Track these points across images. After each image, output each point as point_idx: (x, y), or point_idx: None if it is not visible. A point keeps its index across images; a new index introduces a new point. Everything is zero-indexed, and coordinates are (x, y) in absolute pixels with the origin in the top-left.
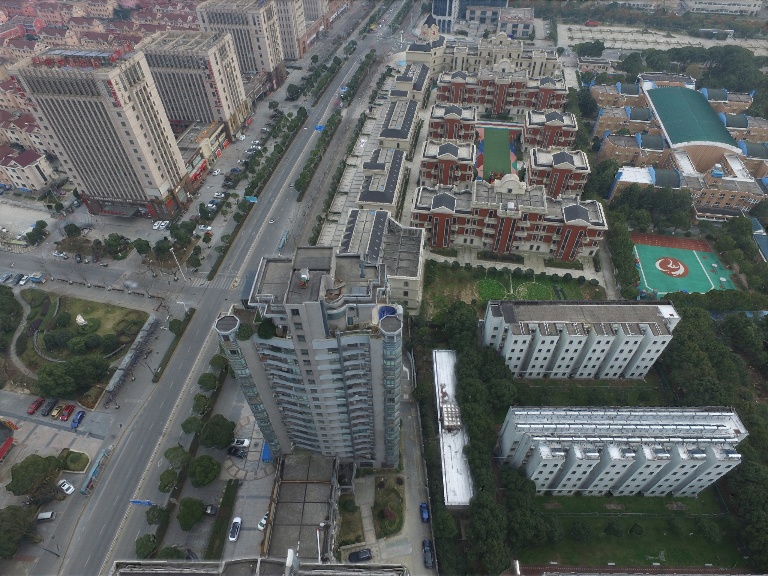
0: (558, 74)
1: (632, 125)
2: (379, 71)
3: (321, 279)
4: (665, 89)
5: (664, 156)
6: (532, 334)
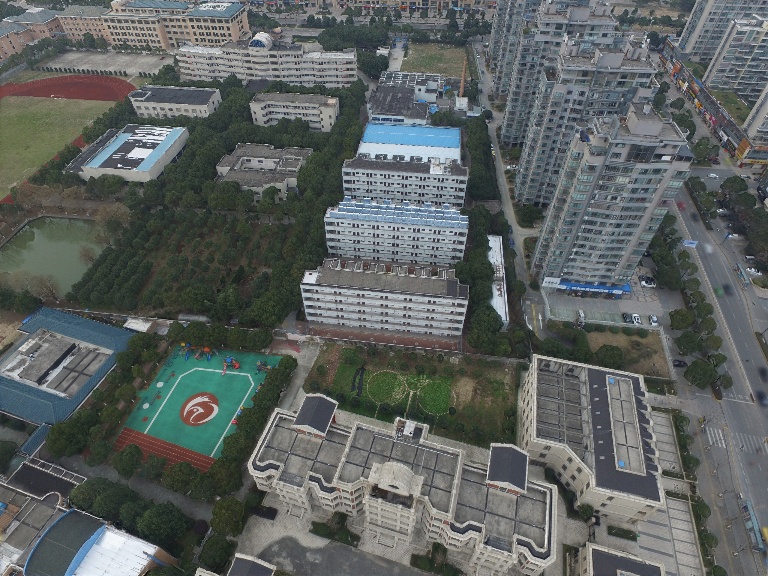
0: None
1: None
2: None
3: None
4: None
5: None
6: None
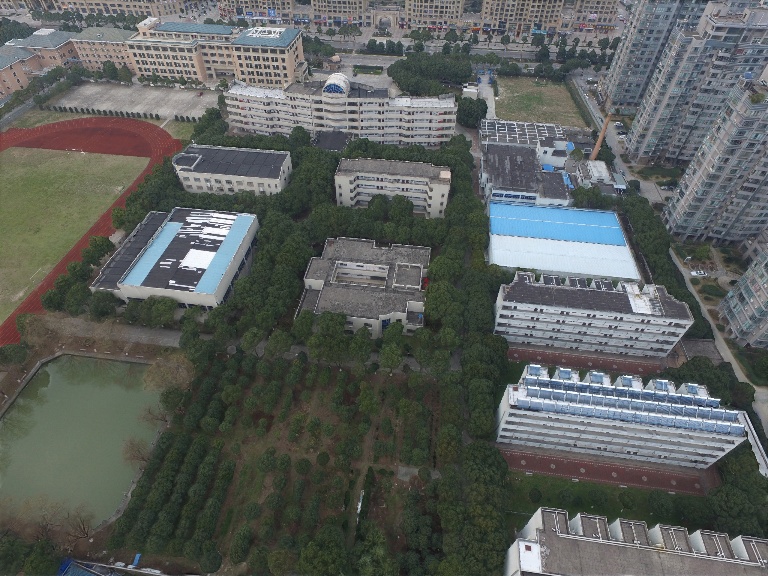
0: None
1: None
2: None
3: None
4: None
5: None
6: None
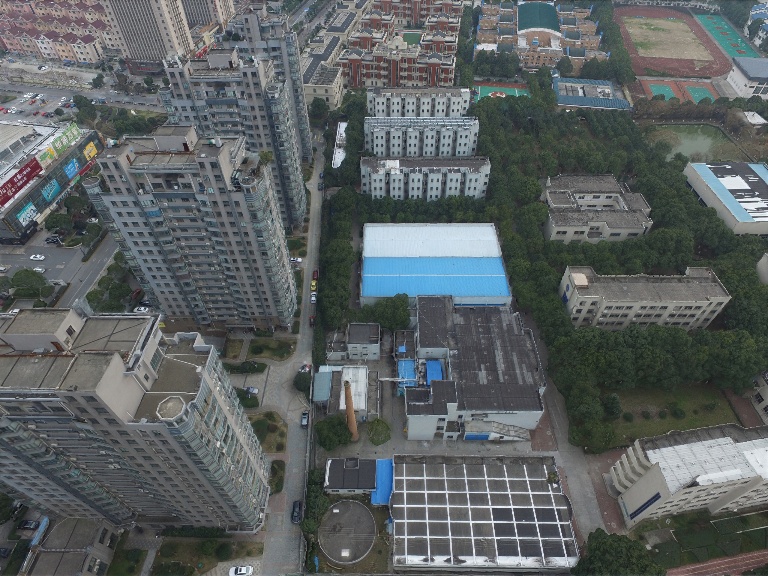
0: (469, 4)
1: (502, 26)
2: (336, 2)
3: (258, 10)
4: (529, 4)
5: (514, 41)
6: (389, 102)
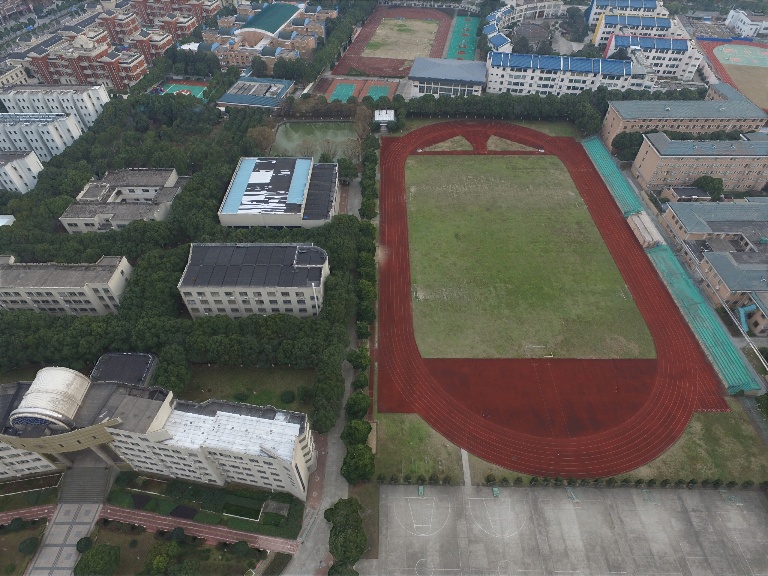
0: None
1: None
2: None
3: None
4: (273, 4)
5: None
6: None
